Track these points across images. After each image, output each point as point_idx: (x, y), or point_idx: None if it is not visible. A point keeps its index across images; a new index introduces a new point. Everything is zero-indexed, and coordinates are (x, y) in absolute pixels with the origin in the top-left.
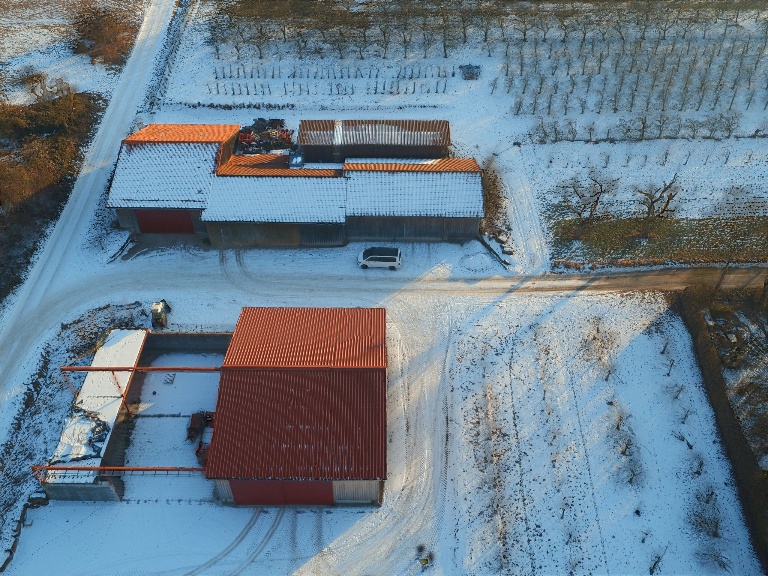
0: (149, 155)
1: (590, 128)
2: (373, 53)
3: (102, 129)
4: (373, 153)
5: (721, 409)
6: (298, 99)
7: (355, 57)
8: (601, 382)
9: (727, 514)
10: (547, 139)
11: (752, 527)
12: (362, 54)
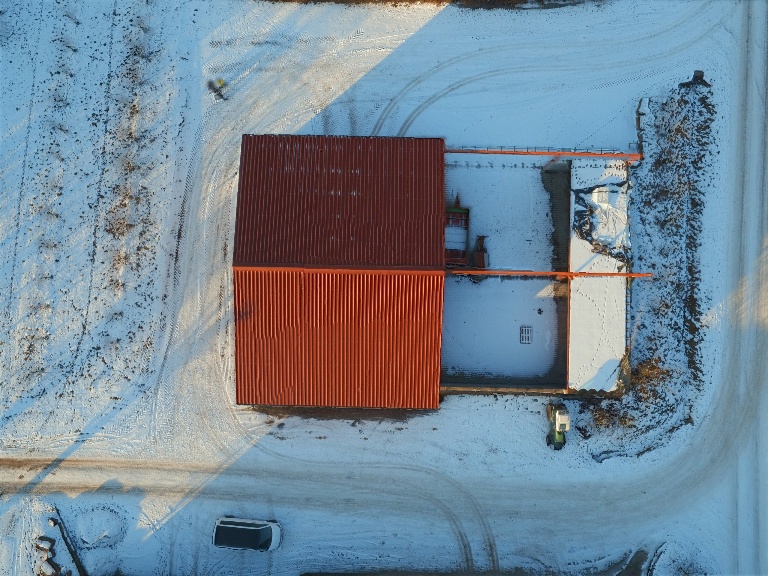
0: None
1: None
2: None
3: None
4: None
5: None
6: None
7: None
8: None
9: None
10: None
11: None
12: None
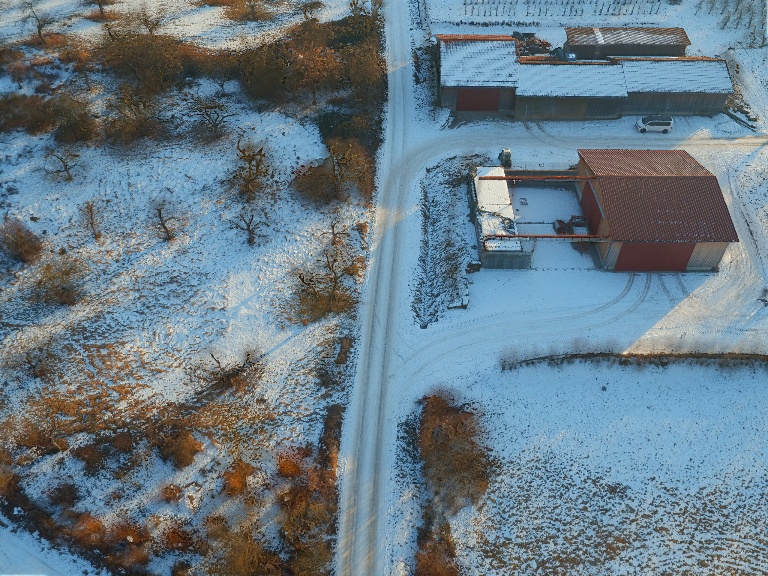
0: (463, 49)
1: None
2: None
3: (389, 41)
4: (626, 52)
5: None
6: (540, 18)
7: None
8: None
9: None
10: (754, 45)
11: None
12: None
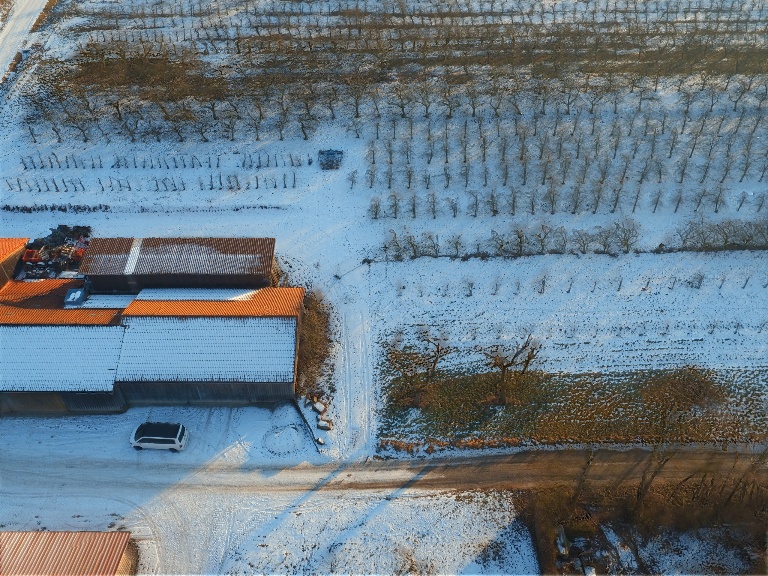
0: None
1: (456, 242)
2: (221, 133)
3: None
4: (178, 282)
5: None
6: (115, 198)
7: (198, 139)
8: None
9: None
10: (405, 254)
11: None
12: (207, 135)
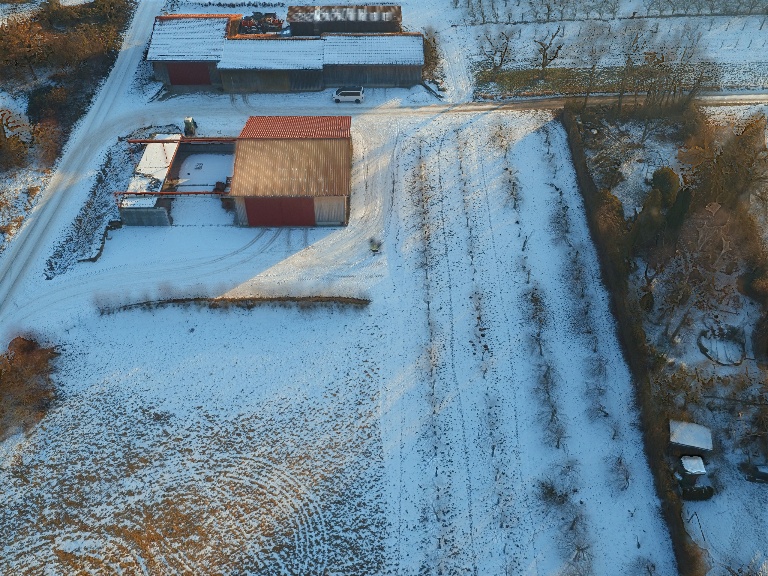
0: (176, 26)
1: (509, 13)
2: None
3: (135, 21)
4: (344, 29)
5: (579, 167)
6: None
7: None
8: (501, 158)
9: (576, 222)
10: (477, 22)
11: (591, 227)
12: None
